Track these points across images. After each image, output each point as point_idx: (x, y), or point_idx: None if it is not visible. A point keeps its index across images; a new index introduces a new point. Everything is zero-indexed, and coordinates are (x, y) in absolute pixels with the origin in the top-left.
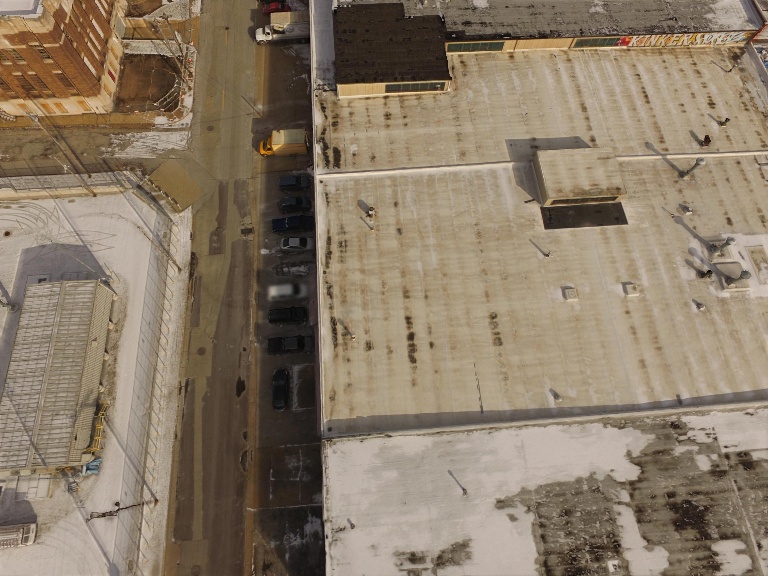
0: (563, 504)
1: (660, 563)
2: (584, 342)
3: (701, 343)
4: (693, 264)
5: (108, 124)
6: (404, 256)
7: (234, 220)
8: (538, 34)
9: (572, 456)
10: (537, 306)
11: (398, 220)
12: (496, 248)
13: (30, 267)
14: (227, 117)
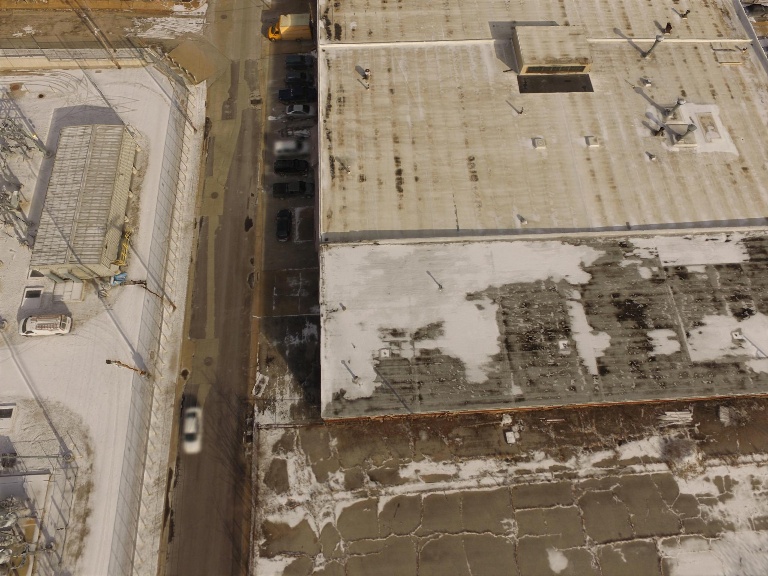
0: (524, 299)
1: (603, 344)
2: (549, 180)
3: (651, 185)
4: (649, 125)
5: (131, 9)
6: (395, 110)
7: (244, 92)
8: None
9: (533, 264)
10: (510, 152)
11: (391, 82)
12: (476, 106)
13: (62, 123)
14: (239, 8)
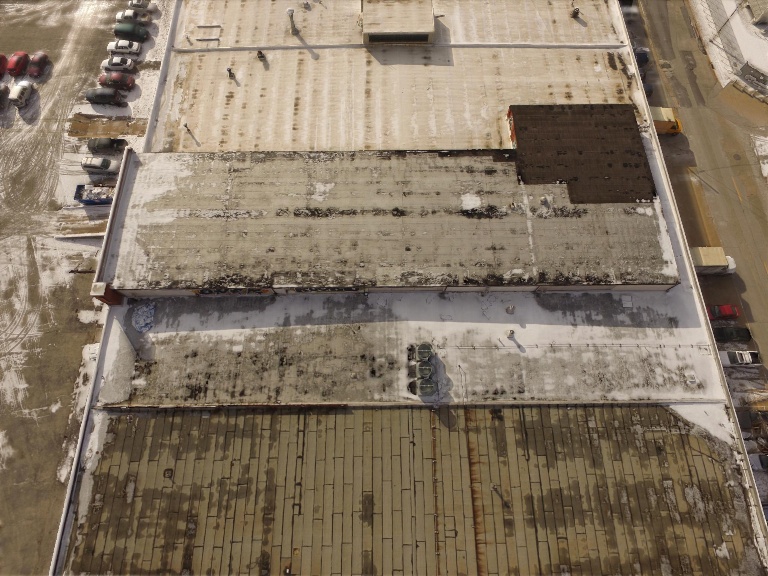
0: None
1: None
2: None
3: None
4: None
5: None
6: None
7: (680, 74)
8: (406, 155)
9: None
10: None
11: (552, 11)
12: None
13: None
14: (725, 169)
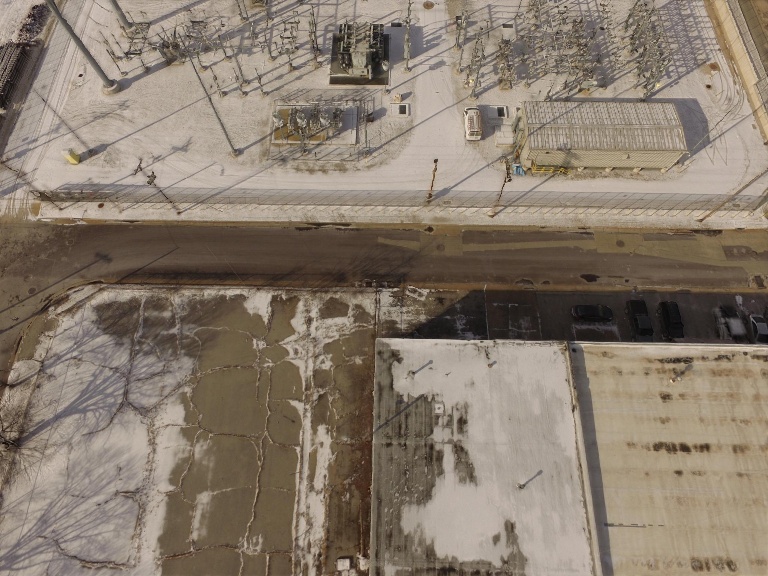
0: None
1: None
2: None
3: None
4: None
5: None
6: None
7: None
8: None
9: None
10: None
11: None
12: None
13: (681, 106)
14: None
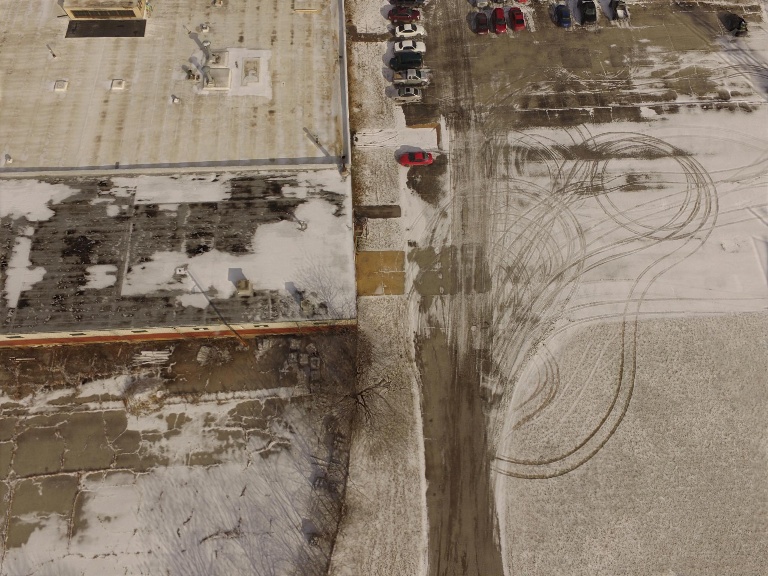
0: None
1: (35, 278)
2: (55, 121)
3: (161, 126)
4: (188, 69)
5: None
6: None
7: None
8: None
9: None
10: (27, 94)
11: None
12: (13, 50)
13: None
14: None
